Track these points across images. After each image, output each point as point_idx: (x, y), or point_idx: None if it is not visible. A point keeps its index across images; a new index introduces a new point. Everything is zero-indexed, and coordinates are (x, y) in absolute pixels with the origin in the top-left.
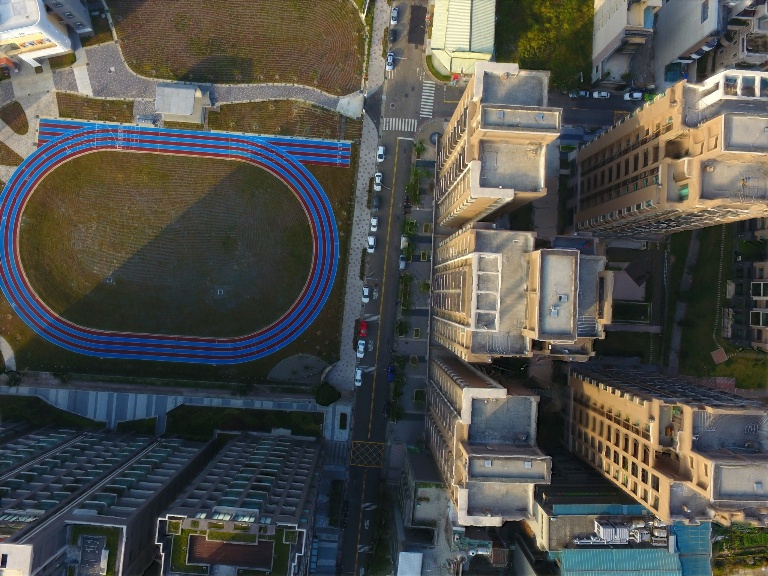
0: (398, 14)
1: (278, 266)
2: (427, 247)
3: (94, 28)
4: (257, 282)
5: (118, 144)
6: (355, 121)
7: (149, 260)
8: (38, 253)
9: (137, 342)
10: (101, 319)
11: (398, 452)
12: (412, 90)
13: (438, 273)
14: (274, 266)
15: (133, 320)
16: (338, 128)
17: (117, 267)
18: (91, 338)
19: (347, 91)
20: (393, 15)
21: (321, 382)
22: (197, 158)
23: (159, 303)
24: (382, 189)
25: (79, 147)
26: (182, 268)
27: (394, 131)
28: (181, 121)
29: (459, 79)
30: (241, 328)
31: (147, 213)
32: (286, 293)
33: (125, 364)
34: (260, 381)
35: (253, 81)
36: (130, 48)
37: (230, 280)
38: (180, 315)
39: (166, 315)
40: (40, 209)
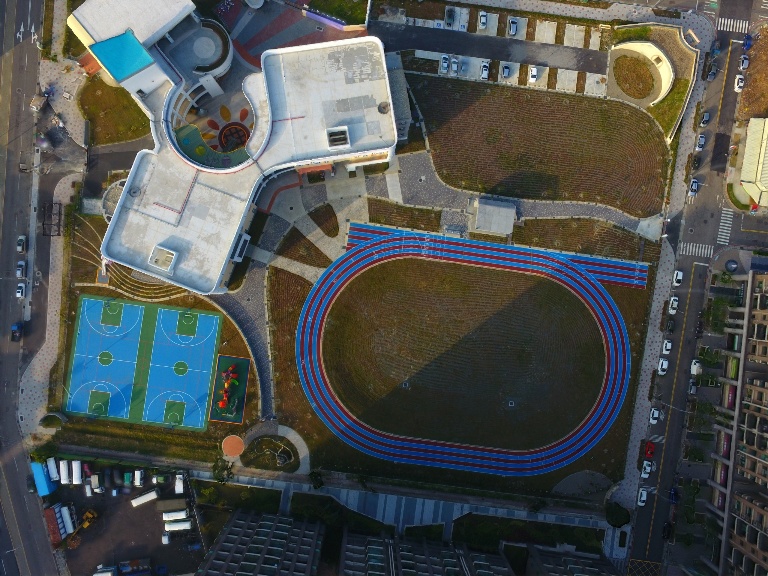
0: (704, 141)
1: (569, 382)
2: (716, 373)
3: (409, 136)
4: (548, 396)
5: (424, 252)
6: (654, 244)
7: (445, 368)
8: (339, 355)
9: (430, 449)
10: (396, 424)
11: (674, 573)
12: (711, 216)
13: (756, 413)
14: (565, 381)
15: (427, 427)
16: (637, 250)
17: (414, 373)
18: (386, 442)
19: (648, 213)
20: (700, 142)
21: (605, 499)
22: (499, 271)
23: (452, 411)
24: (676, 313)
25: (386, 253)
26: (476, 378)
27: (691, 256)
28: (486, 233)
29: (758, 209)
30: (531, 441)
31: (446, 321)
32: (576, 409)
33: (417, 470)
34: (544, 494)
35: (558, 198)
36: (441, 158)
37: (522, 393)
38: (472, 424)
39: (458, 423)
40: (344, 311)
